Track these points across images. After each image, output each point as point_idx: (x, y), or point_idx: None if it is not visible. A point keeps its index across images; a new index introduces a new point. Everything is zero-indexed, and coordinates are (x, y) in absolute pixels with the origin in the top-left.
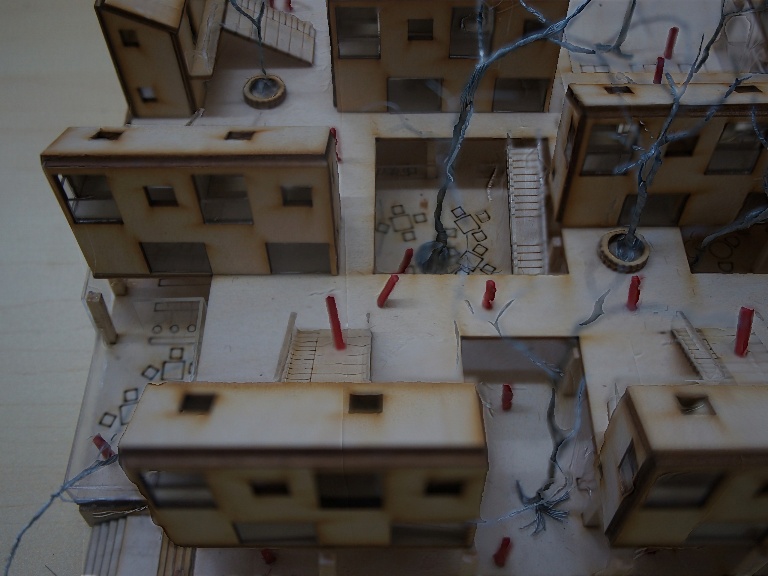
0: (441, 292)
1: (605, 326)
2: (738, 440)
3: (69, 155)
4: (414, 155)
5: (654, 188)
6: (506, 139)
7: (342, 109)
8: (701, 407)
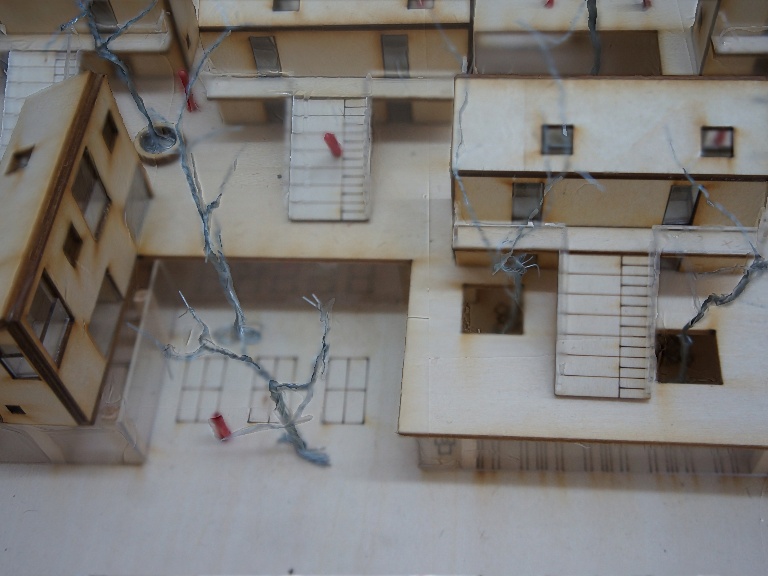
0: None
1: None
2: None
3: None
4: None
5: None
6: None
7: None
8: None
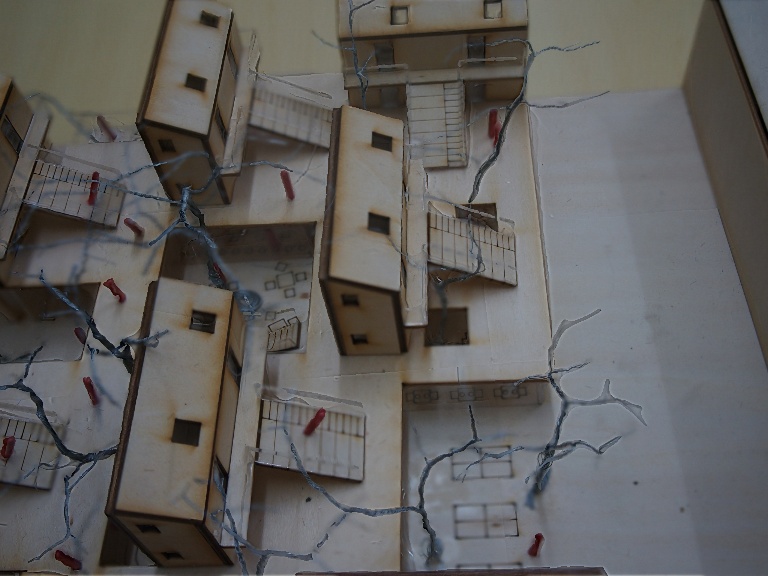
0: (143, 270)
1: None
2: None
3: (175, 0)
4: None
5: None
6: (308, 319)
7: None
8: None
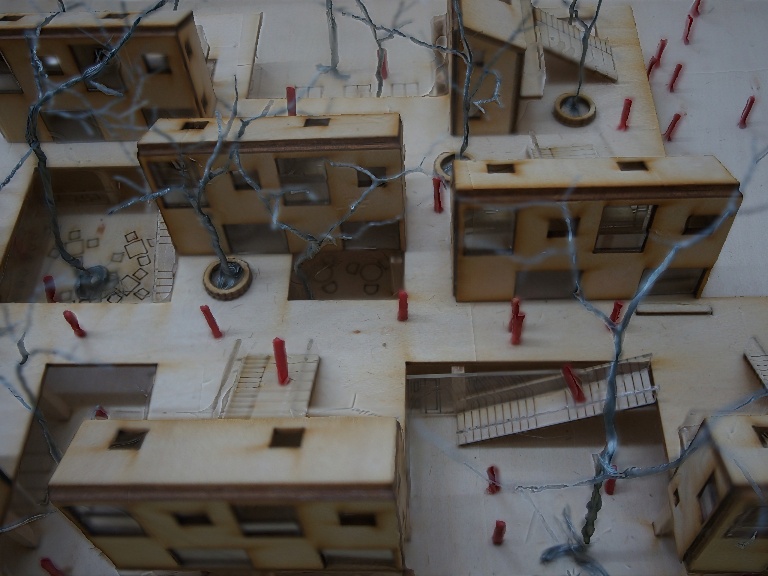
0: (43, 320)
1: (185, 353)
2: (132, 476)
3: None
4: (86, 182)
5: (244, 218)
6: None
7: (11, 139)
8: (135, 442)
